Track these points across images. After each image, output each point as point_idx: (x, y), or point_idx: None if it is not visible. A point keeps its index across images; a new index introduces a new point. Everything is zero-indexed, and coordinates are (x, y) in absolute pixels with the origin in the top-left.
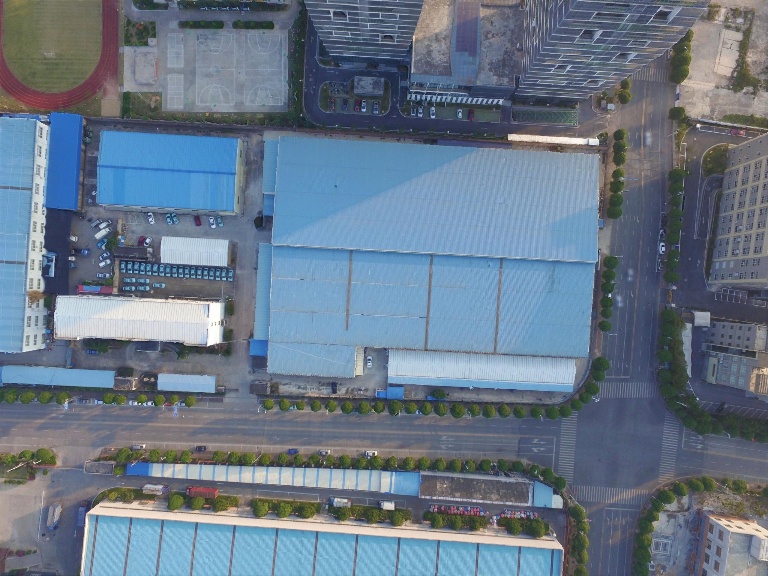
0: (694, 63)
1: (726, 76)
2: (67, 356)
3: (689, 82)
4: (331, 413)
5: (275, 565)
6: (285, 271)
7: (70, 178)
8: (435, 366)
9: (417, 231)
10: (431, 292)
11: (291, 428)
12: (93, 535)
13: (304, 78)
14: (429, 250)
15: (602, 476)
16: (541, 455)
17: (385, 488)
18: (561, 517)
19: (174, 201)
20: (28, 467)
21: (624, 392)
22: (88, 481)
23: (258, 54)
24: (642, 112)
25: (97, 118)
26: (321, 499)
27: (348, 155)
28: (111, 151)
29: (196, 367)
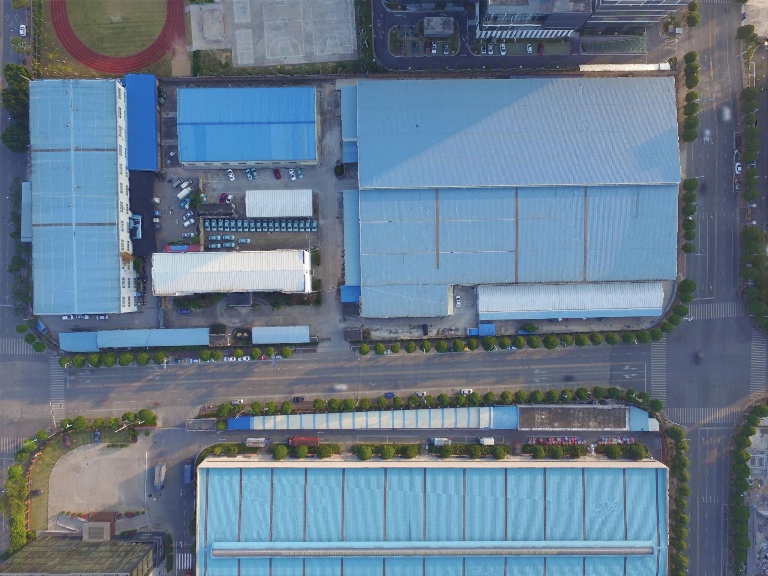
0: None
1: None
2: (160, 317)
3: (754, 1)
4: (424, 355)
5: (386, 504)
6: (373, 214)
7: (150, 139)
8: (525, 299)
9: (501, 165)
10: (518, 225)
11: (386, 373)
12: (205, 488)
13: (372, 24)
14: (515, 183)
15: (694, 397)
16: (633, 381)
17: (484, 423)
18: (657, 440)
19: (256, 154)
20: (130, 430)
21: (710, 313)
22: (189, 440)
23: (324, 3)
24: (709, 34)
25: (170, 78)
26: (420, 440)
27: (427, 95)
28: (189, 108)
29: (287, 319)
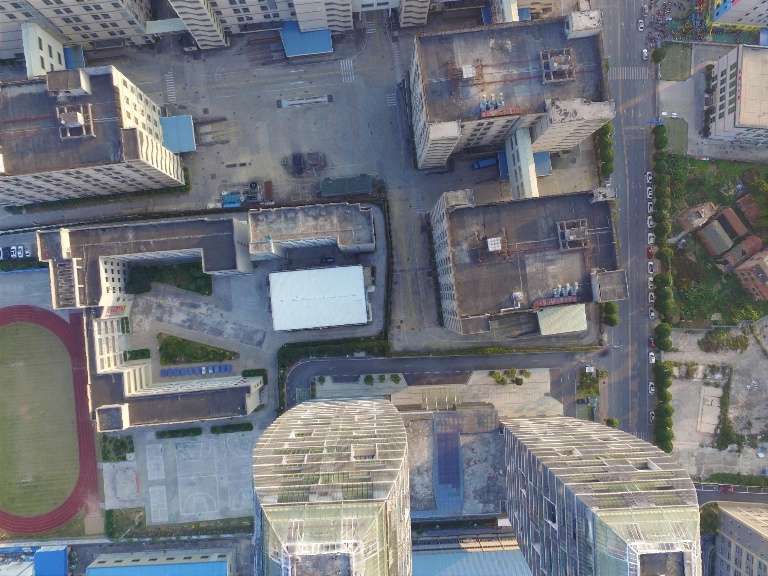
0: (677, 423)
1: (709, 433)
2: None
3: (673, 443)
4: None
5: None
6: None
7: None
8: None
9: None
10: None
11: None
12: None
13: None
14: None
15: None
16: None
17: None
18: None
19: None
20: None
21: None
22: None
23: (239, 457)
24: None
25: None
26: None
27: None
28: None
29: None
